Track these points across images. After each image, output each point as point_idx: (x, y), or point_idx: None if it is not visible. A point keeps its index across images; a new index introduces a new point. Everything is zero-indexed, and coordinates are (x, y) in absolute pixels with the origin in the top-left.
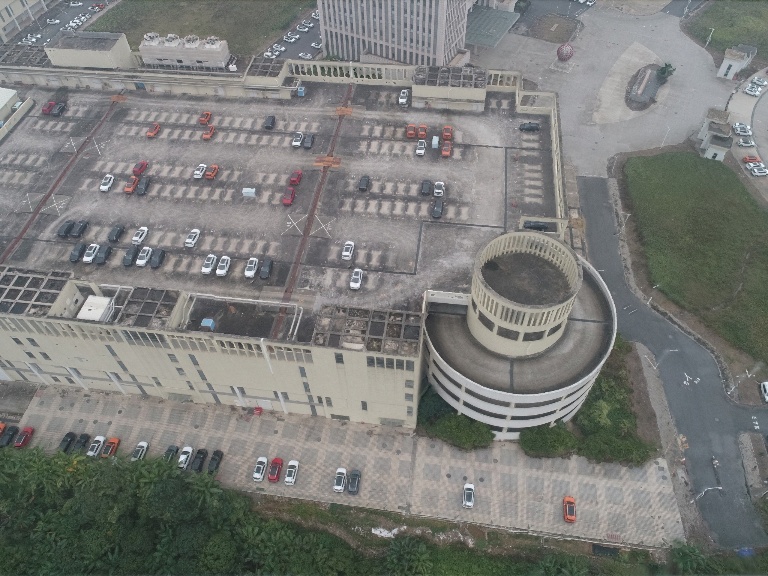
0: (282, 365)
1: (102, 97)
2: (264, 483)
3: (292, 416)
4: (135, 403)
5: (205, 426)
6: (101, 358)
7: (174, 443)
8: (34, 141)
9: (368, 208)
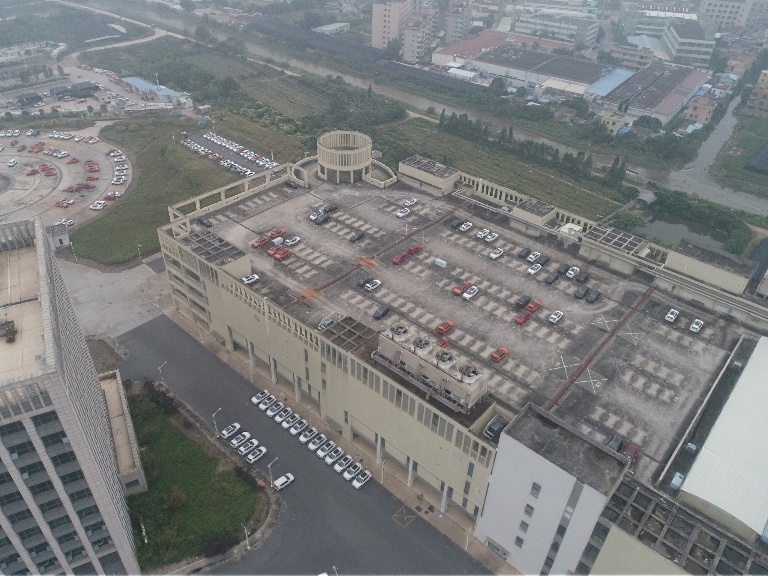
0: None
1: None
2: None
3: None
4: None
5: None
6: None
7: None
8: (641, 410)
9: (369, 227)
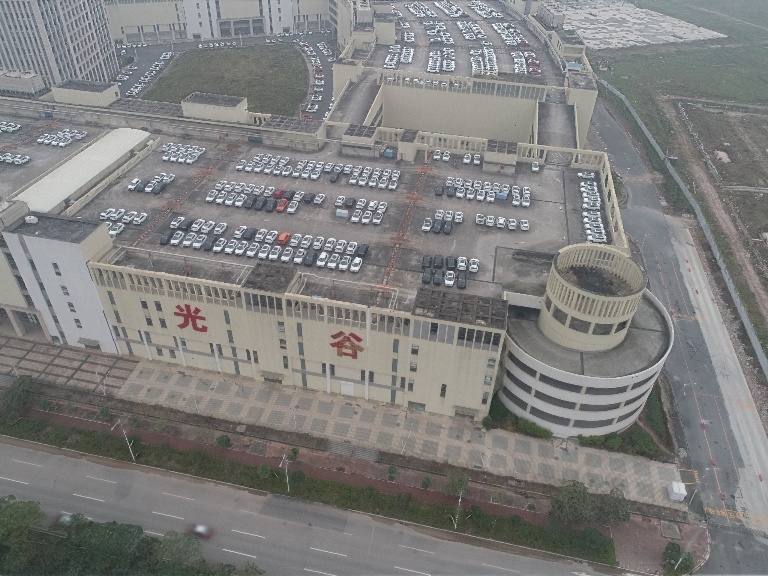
0: None
1: None
2: None
3: None
4: None
5: None
6: None
7: None
8: None
9: None
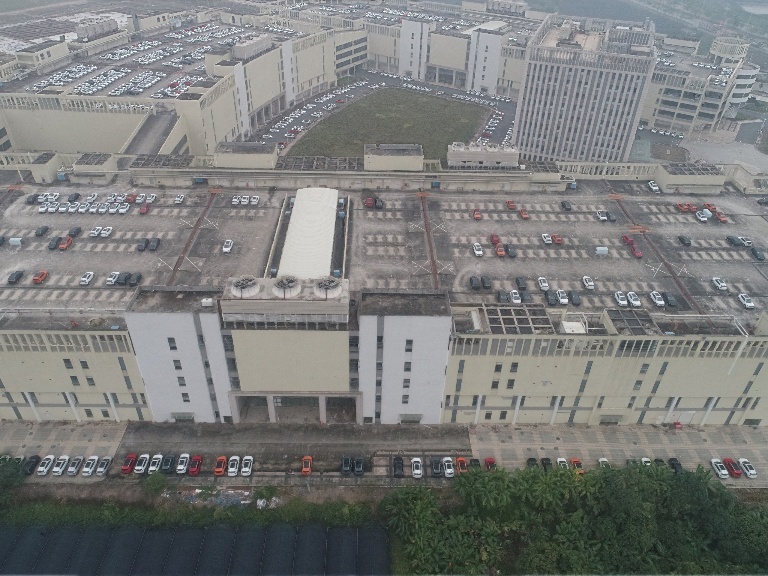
0: (745, 363)
1: (406, 194)
2: (729, 480)
3: (708, 427)
4: (566, 430)
5: (642, 442)
6: (569, 379)
7: (626, 458)
8: (379, 226)
9: (702, 256)
